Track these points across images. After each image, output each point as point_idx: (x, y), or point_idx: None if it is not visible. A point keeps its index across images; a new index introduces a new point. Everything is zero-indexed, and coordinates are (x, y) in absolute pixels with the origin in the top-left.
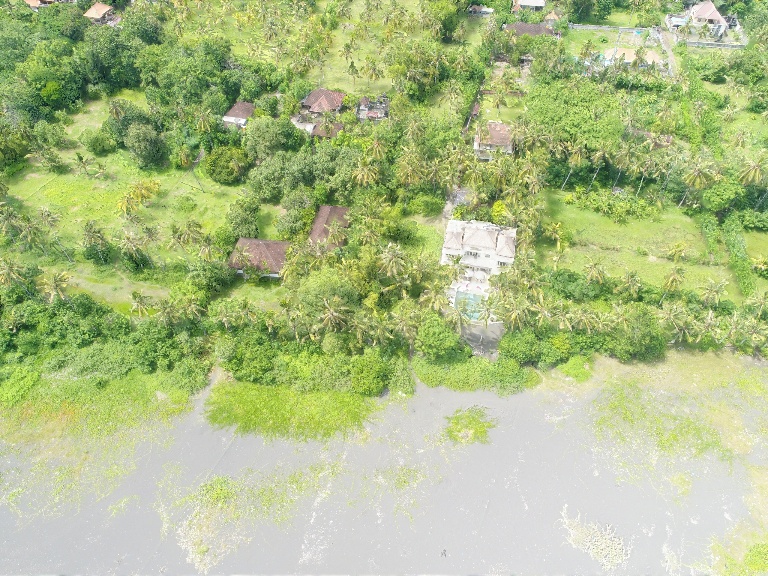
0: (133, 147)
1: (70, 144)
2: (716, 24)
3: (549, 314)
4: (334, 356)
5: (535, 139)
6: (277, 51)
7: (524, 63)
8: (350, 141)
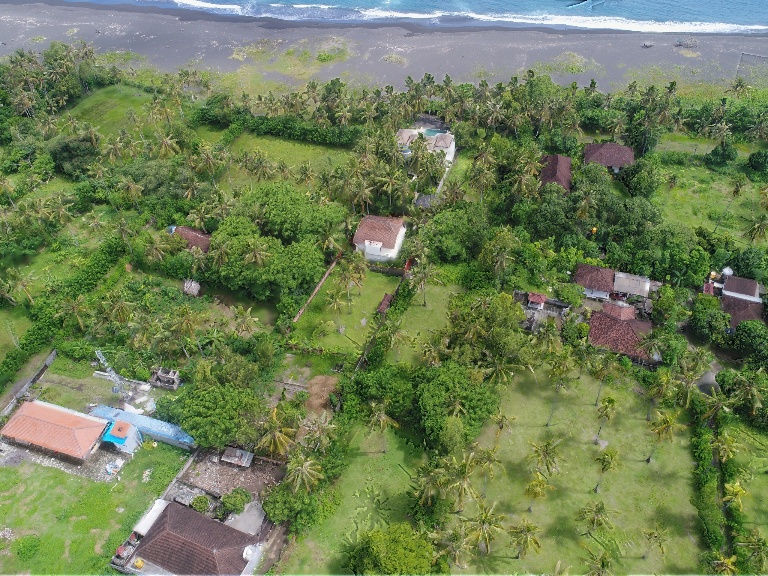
0: None
1: None
2: None
3: None
4: None
5: None
6: None
7: None
8: None
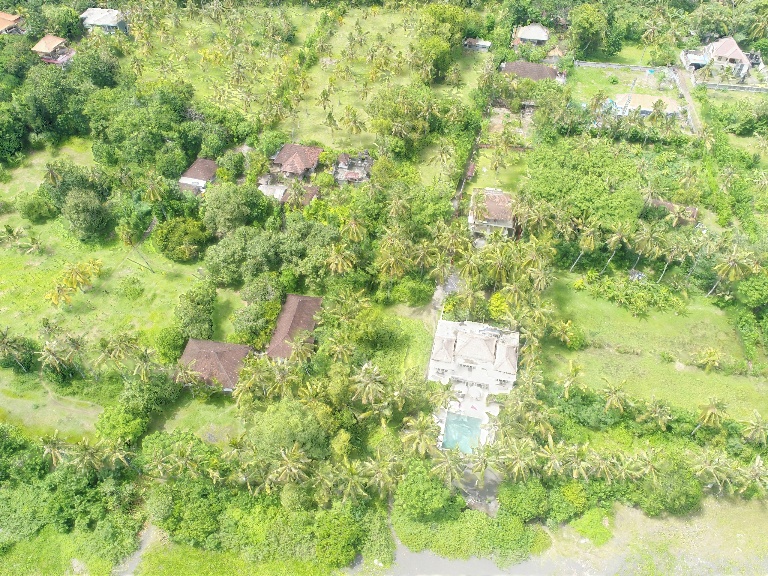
0: (71, 219)
1: (4, 207)
2: (738, 63)
3: (560, 462)
4: (295, 512)
5: (540, 218)
6: (245, 98)
7: (525, 109)
8: (325, 210)
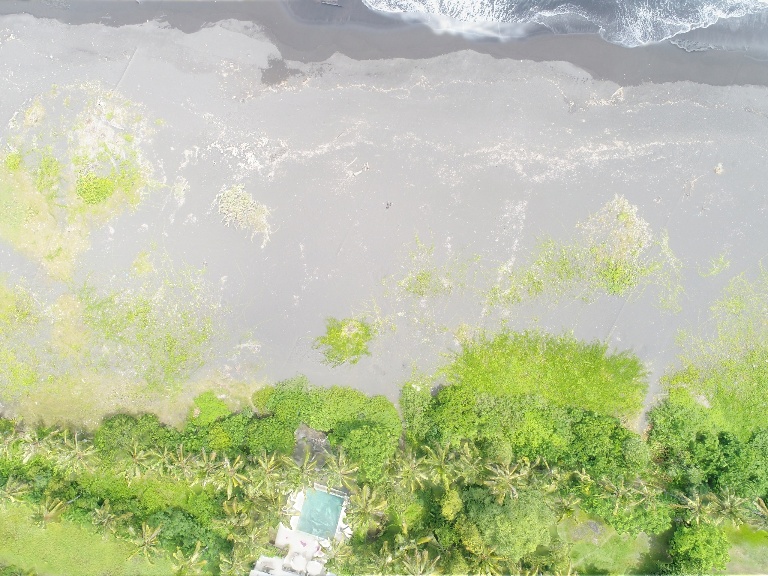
0: None
1: None
2: None
3: None
4: None
5: None
6: None
7: None
8: None
